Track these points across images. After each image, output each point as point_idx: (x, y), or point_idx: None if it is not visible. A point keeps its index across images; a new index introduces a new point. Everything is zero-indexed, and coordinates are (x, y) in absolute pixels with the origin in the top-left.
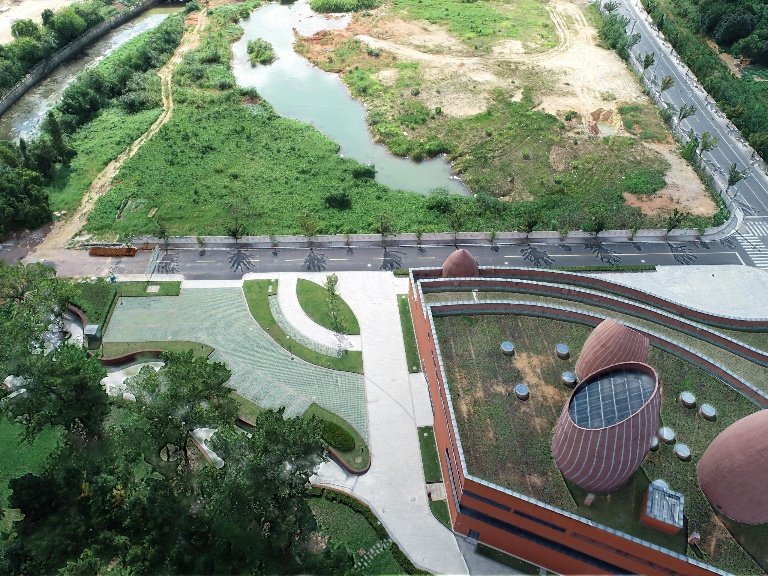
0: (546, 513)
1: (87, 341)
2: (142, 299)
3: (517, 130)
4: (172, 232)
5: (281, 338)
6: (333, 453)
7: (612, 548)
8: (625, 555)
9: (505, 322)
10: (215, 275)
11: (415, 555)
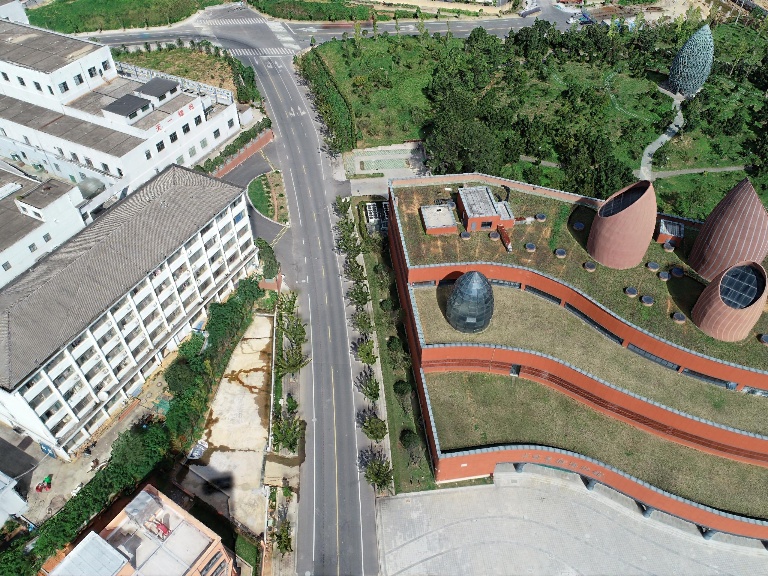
0: None
1: None
2: None
3: None
4: None
5: None
6: None
7: None
8: None
9: None
10: None
11: None
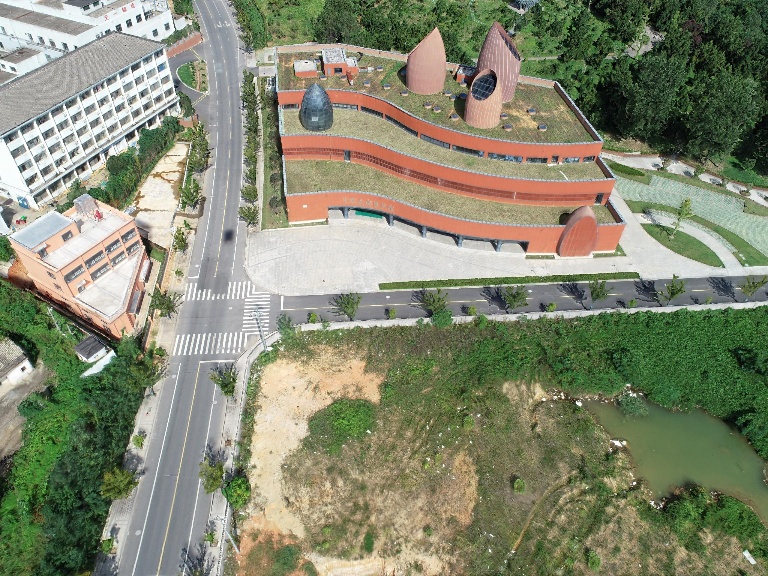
0: None
1: None
2: None
3: (538, 575)
4: None
5: (700, 219)
6: None
7: None
8: None
9: (546, 142)
10: None
11: None
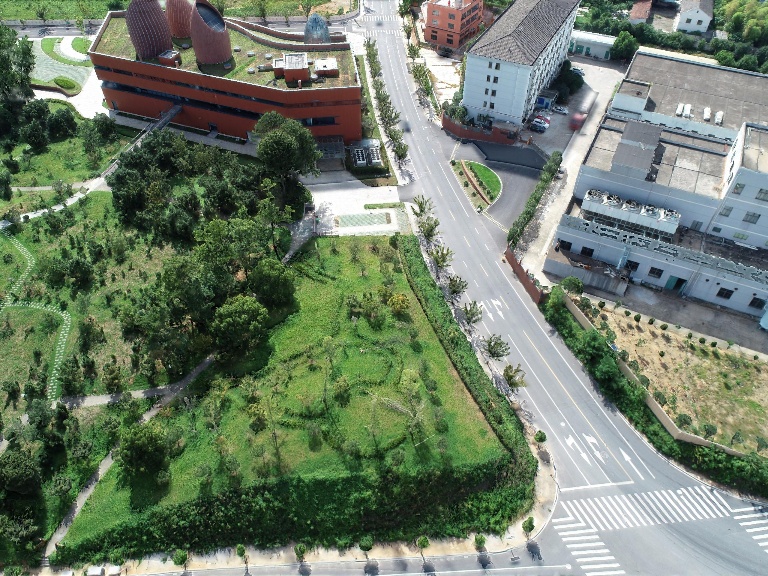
0: (120, 63)
1: None
2: None
3: None
4: None
5: (54, 56)
6: (62, 90)
7: (149, 77)
8: (155, 80)
9: None
10: None
11: (86, 115)
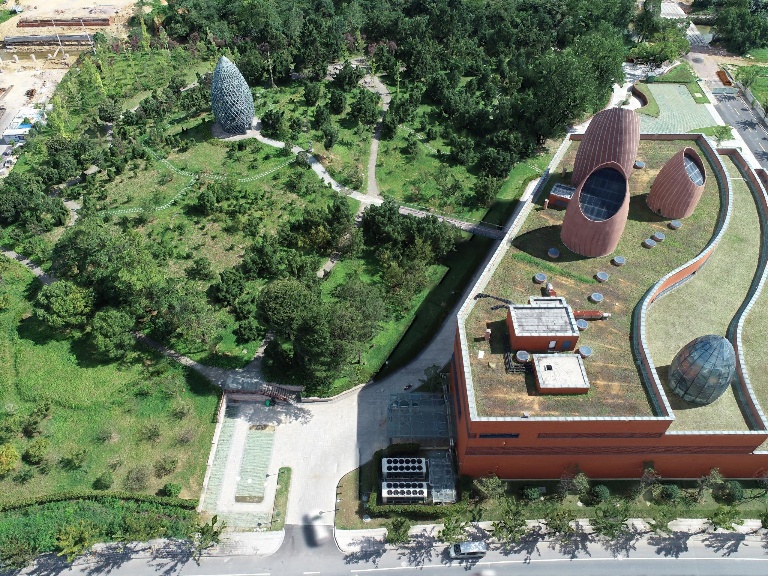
0: None
1: (645, 79)
2: (687, 92)
3: None
4: (759, 96)
5: None
6: None
7: None
8: None
9: None
10: (725, 115)
11: None
